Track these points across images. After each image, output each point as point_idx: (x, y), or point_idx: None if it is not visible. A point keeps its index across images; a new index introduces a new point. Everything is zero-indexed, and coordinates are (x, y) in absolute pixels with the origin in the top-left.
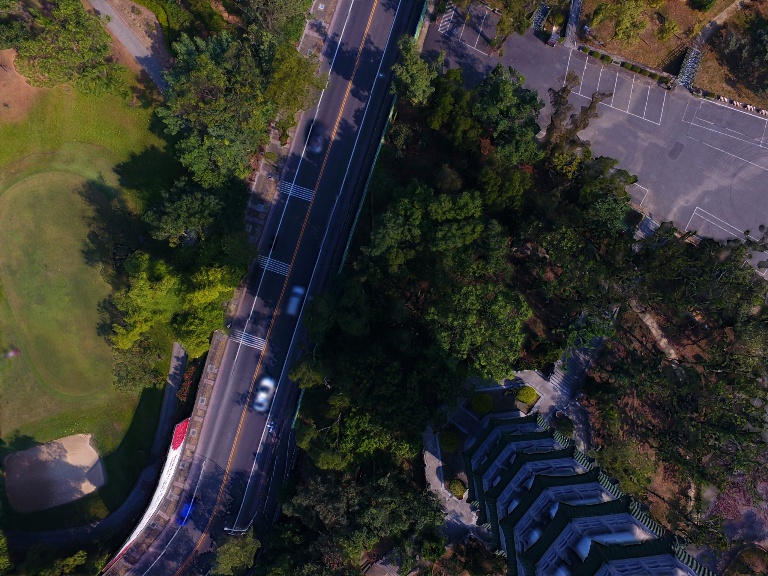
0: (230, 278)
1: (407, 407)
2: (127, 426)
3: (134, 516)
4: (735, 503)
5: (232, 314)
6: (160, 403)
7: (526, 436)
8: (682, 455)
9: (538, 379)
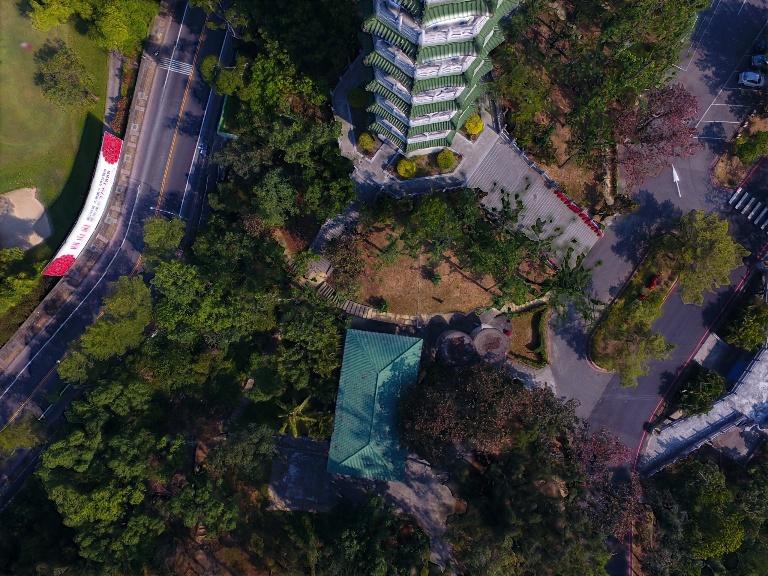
0: None
1: (301, 20)
2: (68, 172)
3: None
4: (640, 156)
5: (159, 42)
6: (98, 146)
7: None
8: None
9: None
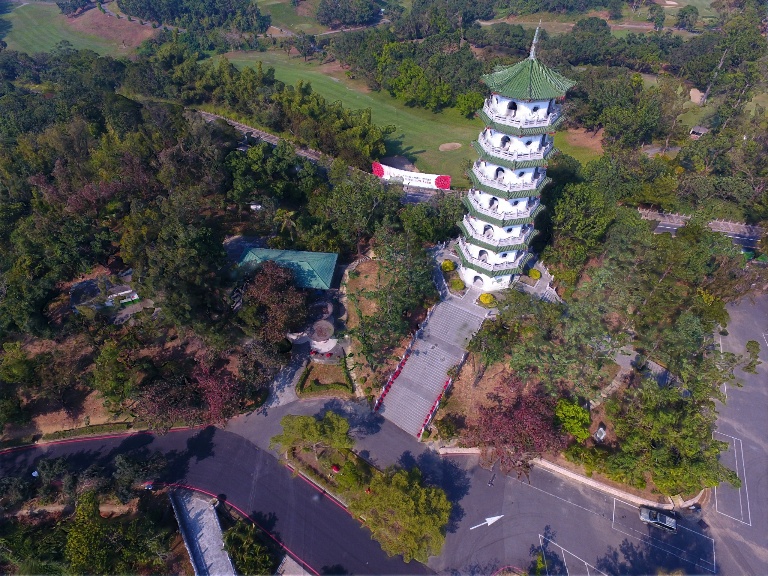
0: None
1: None
2: None
3: None
4: None
5: None
6: None
7: None
8: None
9: (545, 285)
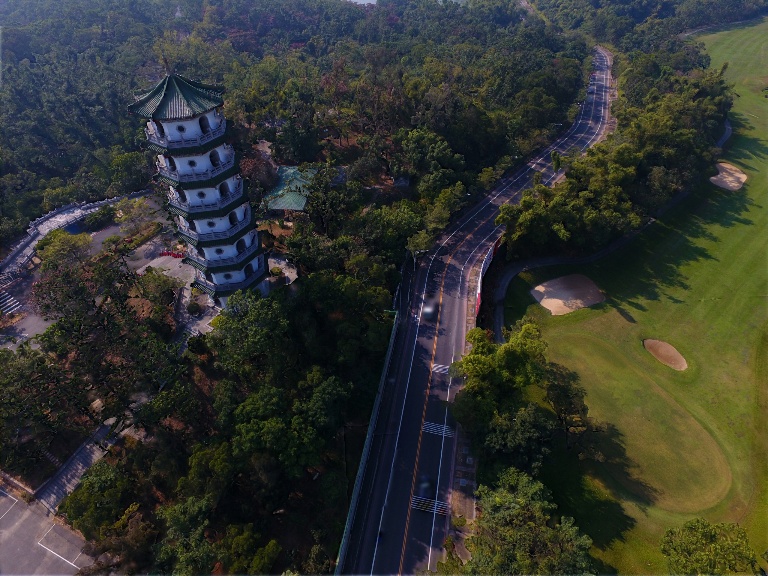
0: None
1: None
2: None
3: (498, 270)
4: (84, 284)
5: None
6: None
7: (225, 269)
8: None
9: None
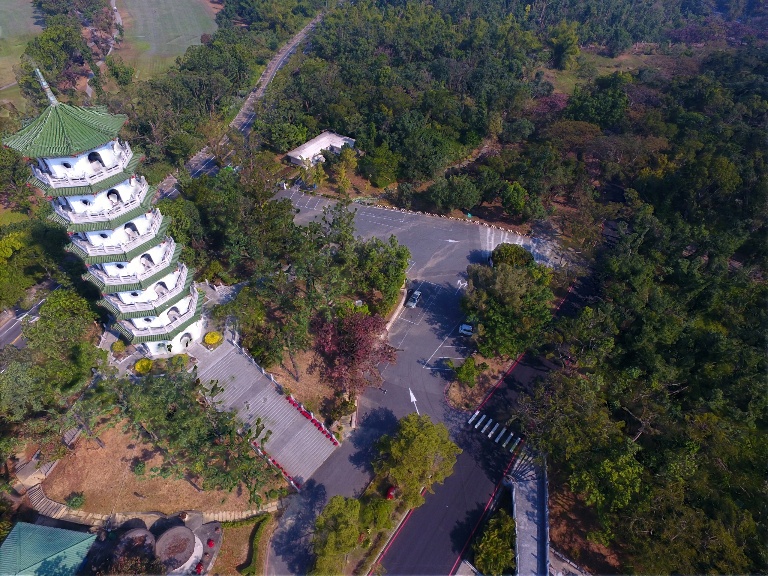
0: (23, 237)
1: None
2: None
3: None
4: (353, 365)
5: None
6: None
7: None
8: (270, 283)
9: (211, 291)
